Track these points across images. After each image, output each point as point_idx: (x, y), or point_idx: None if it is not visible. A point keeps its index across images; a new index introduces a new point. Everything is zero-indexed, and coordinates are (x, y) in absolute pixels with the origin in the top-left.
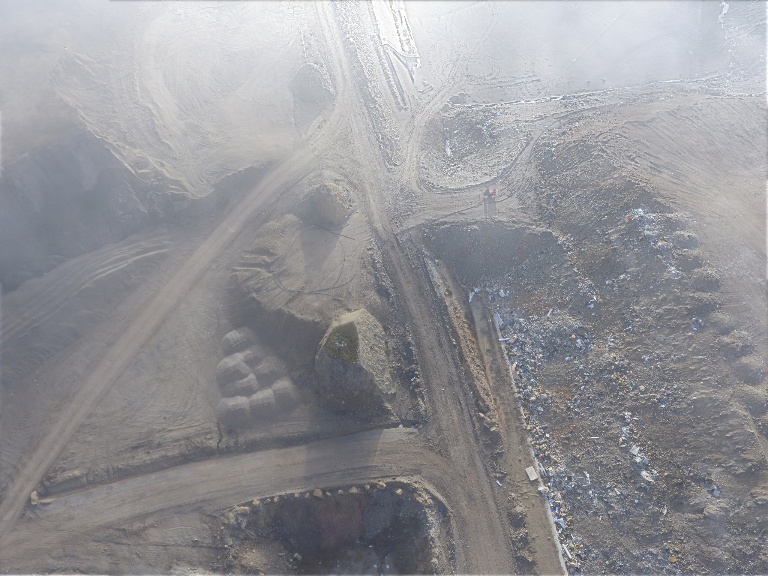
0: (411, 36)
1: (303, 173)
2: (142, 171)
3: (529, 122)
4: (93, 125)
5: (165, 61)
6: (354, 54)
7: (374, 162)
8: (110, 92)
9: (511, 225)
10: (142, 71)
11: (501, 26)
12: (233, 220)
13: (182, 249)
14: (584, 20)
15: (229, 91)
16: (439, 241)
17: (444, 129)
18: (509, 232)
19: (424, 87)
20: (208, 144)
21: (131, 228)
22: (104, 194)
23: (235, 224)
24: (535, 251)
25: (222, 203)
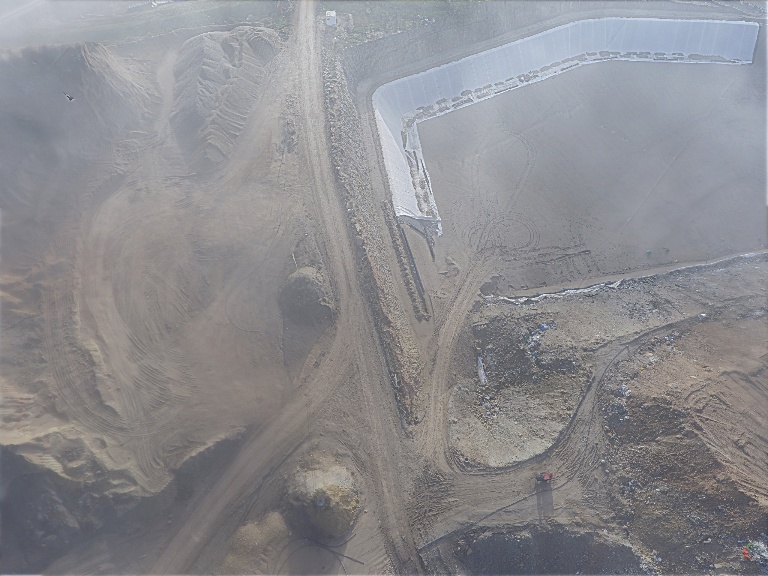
0: (430, 189)
1: (294, 443)
2: (73, 465)
3: (588, 351)
4: (5, 407)
5: (117, 266)
6: (361, 248)
7: (388, 422)
8: (39, 327)
9: (574, 530)
10: (86, 284)
11: (538, 171)
12: (198, 521)
13: (127, 575)
14: (637, 160)
15: (199, 309)
16: (477, 554)
17: (475, 342)
18: (572, 540)
19: (447, 266)
20: (168, 400)
21: (56, 551)
22: (17, 510)
23: (201, 528)
24: (607, 569)
25: (184, 495)
